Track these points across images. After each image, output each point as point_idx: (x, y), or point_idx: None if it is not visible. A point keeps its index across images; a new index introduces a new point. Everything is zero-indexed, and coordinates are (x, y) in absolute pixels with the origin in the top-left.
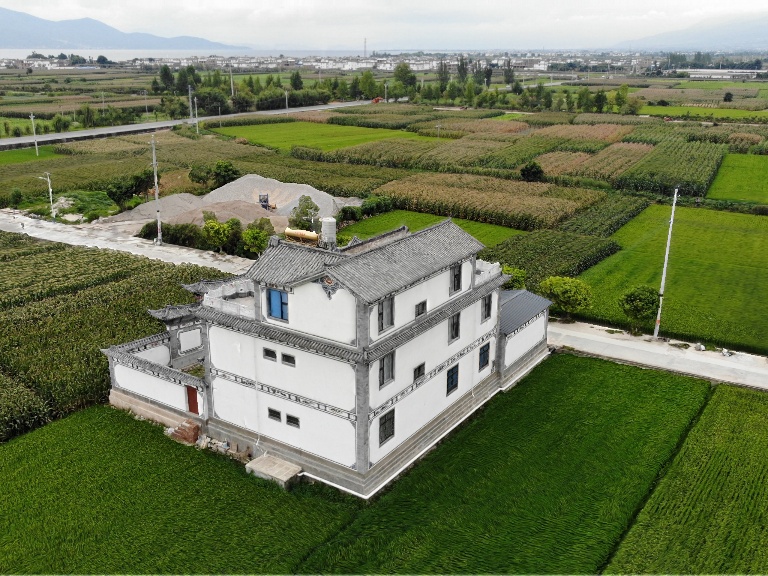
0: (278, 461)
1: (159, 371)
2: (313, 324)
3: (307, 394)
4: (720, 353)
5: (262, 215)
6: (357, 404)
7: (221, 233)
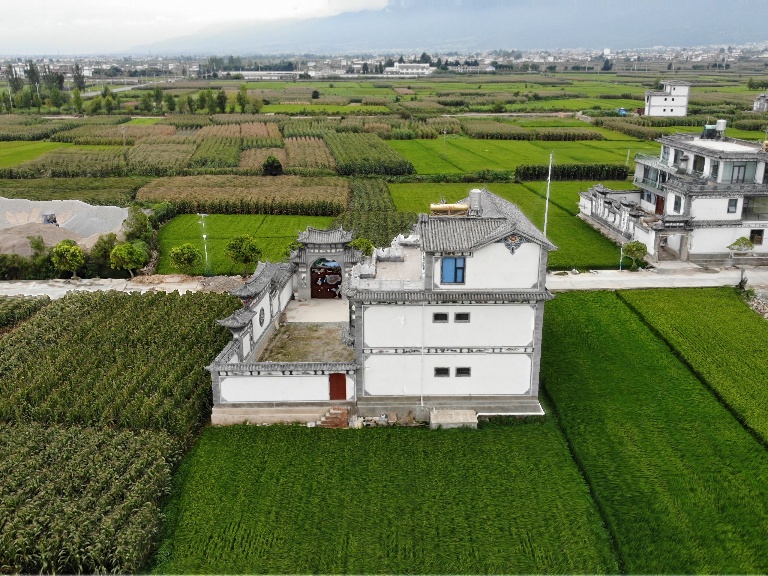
0: (450, 412)
1: (296, 368)
2: (493, 279)
3: (481, 343)
4: (591, 273)
5: (71, 235)
6: (534, 337)
7: (78, 255)
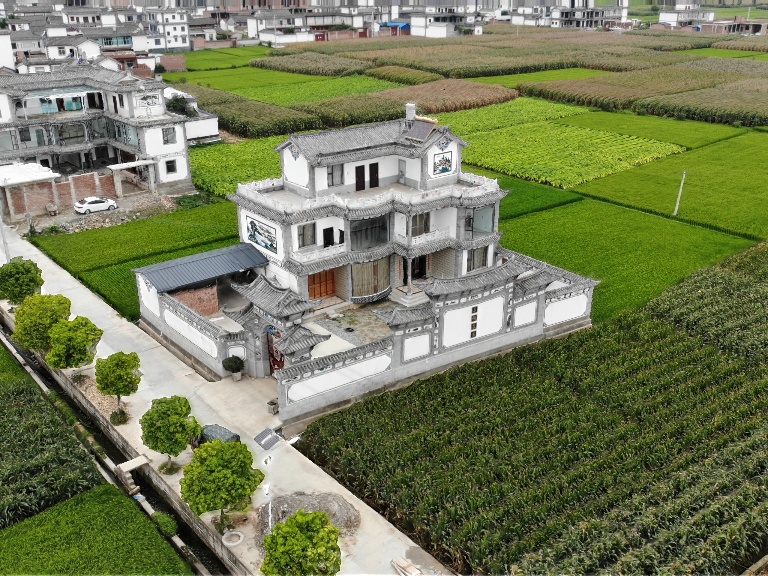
0: None
1: None
2: None
3: None
4: None
5: None
6: None
7: None
